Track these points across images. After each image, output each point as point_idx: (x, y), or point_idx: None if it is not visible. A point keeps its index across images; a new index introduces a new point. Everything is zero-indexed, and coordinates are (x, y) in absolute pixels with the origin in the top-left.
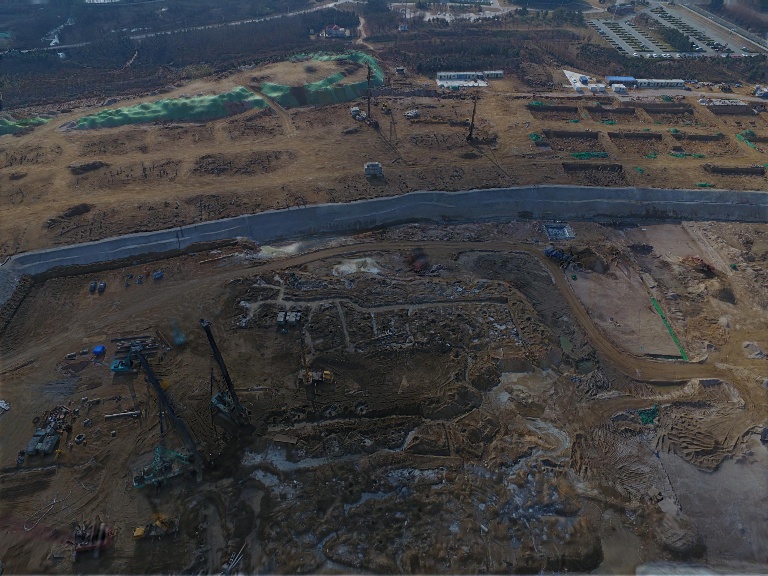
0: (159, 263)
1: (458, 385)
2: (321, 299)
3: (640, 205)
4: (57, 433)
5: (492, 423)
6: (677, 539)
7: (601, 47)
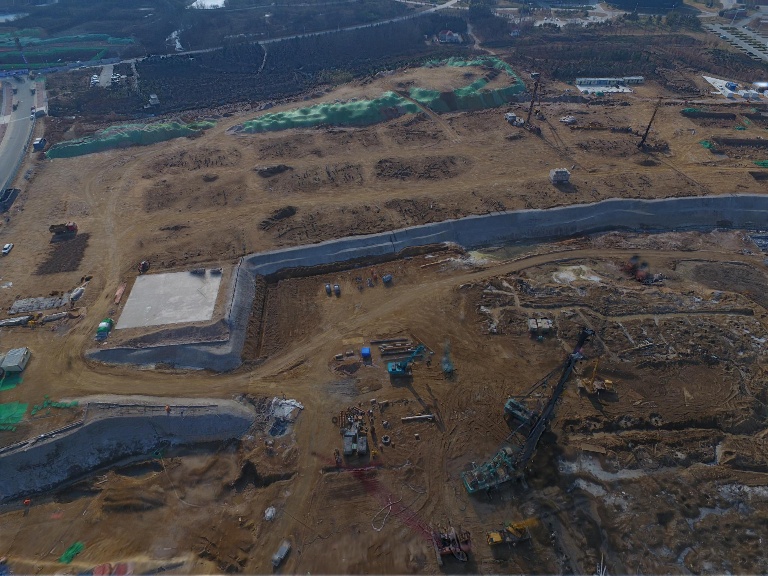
0: (381, 266)
1: (749, 399)
2: (560, 306)
3: None
4: (362, 434)
5: None
6: None
7: (731, 52)
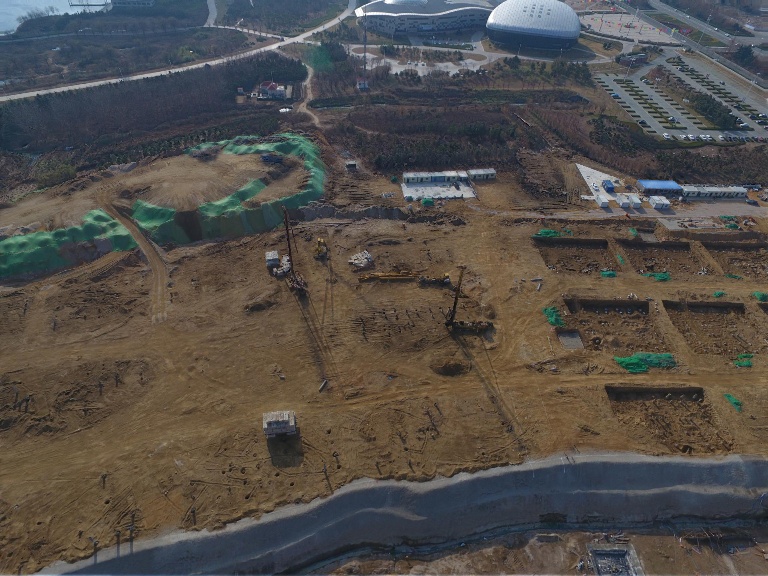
0: None
1: None
2: None
3: (754, 498)
4: None
5: None
6: None
7: (620, 122)
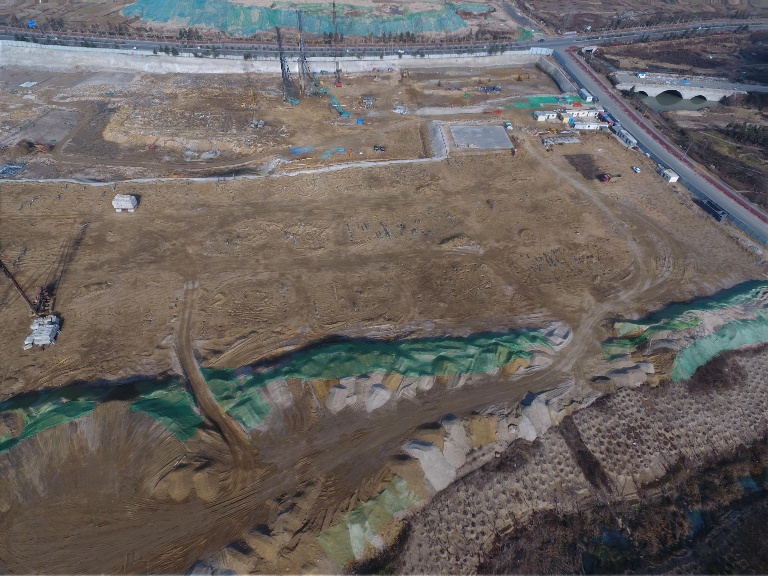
0: (343, 160)
1: (185, 98)
2: None
3: None
4: None
5: None
6: (146, 72)
7: None
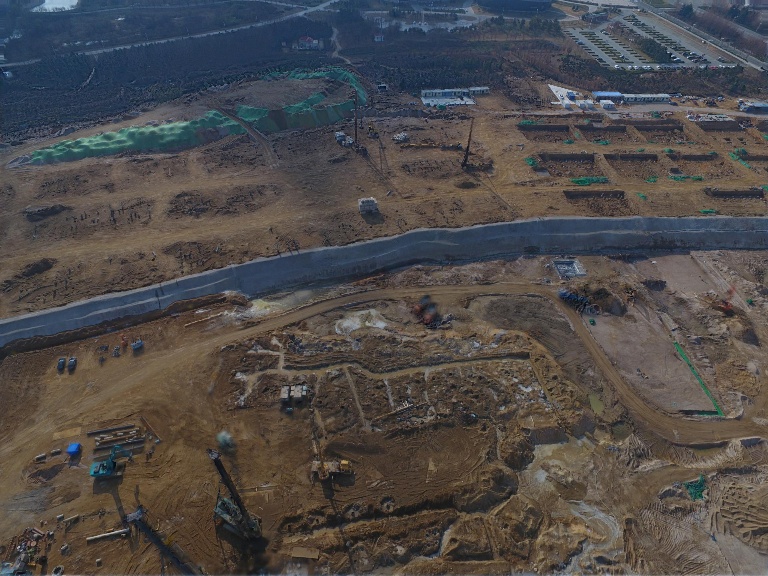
0: (138, 329)
1: (492, 468)
2: (327, 365)
3: (648, 236)
4: (28, 567)
5: (534, 513)
6: None
7: (582, 59)
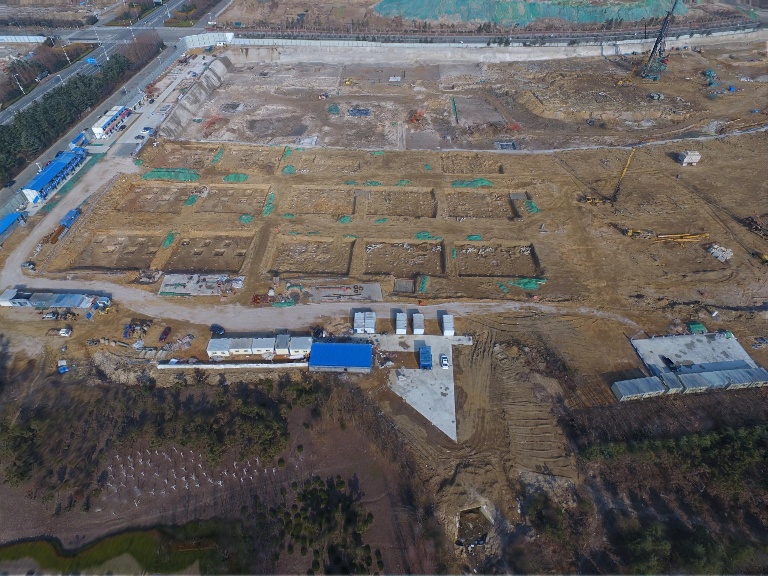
0: (767, 118)
1: None
2: None
3: None
4: None
5: None
6: (487, 62)
7: None
